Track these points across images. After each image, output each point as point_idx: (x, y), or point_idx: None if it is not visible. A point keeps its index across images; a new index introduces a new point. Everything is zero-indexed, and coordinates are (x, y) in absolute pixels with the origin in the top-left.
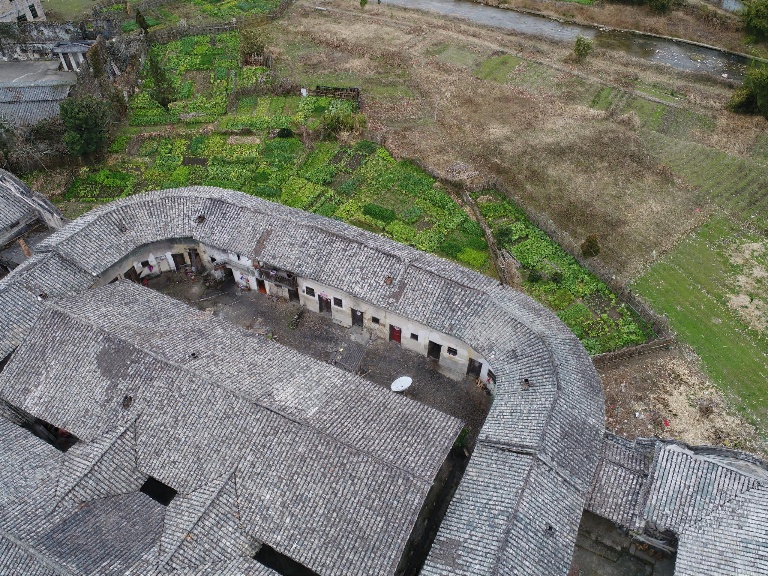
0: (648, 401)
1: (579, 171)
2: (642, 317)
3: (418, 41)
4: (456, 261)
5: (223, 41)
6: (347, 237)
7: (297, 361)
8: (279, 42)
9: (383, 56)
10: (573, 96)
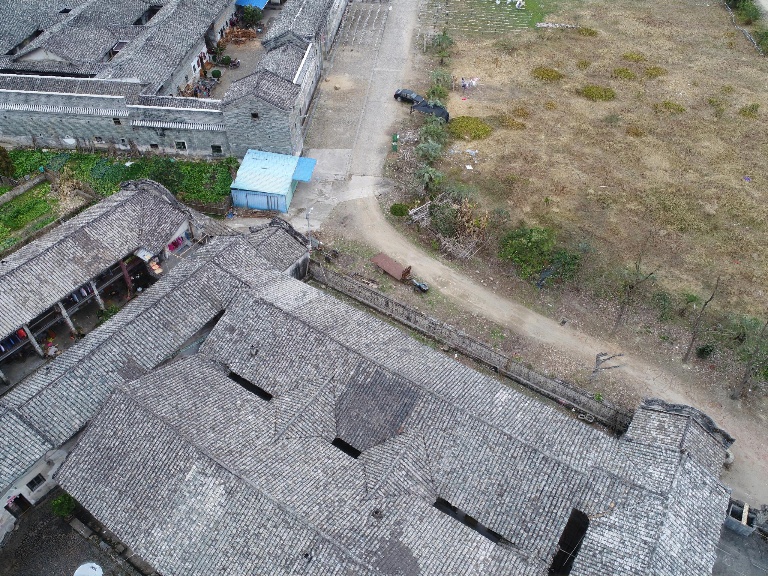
0: None
1: None
2: None
3: None
4: None
5: None
6: None
7: (194, 571)
8: None
9: None
10: None
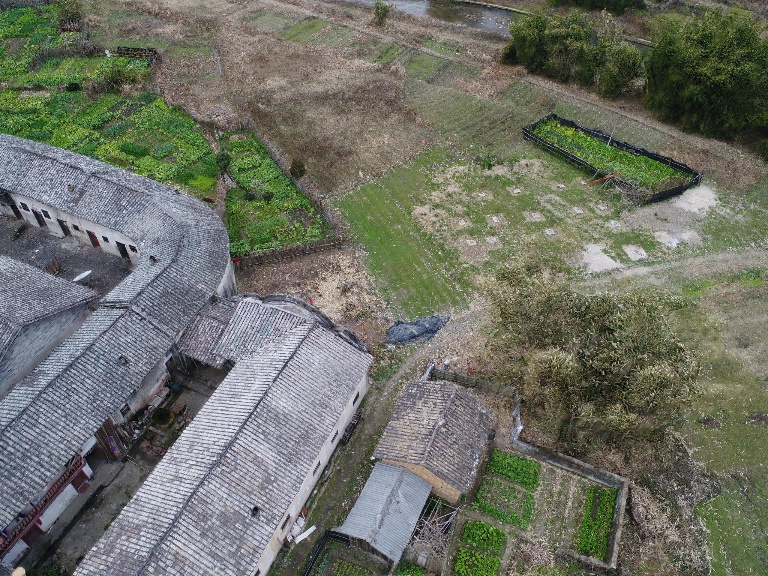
0: (304, 286)
1: (334, 113)
2: (329, 224)
3: (238, 9)
4: (187, 186)
5: (50, 12)
6: (44, 155)
7: None
8: (104, 12)
9: (197, 22)
10: (362, 53)
